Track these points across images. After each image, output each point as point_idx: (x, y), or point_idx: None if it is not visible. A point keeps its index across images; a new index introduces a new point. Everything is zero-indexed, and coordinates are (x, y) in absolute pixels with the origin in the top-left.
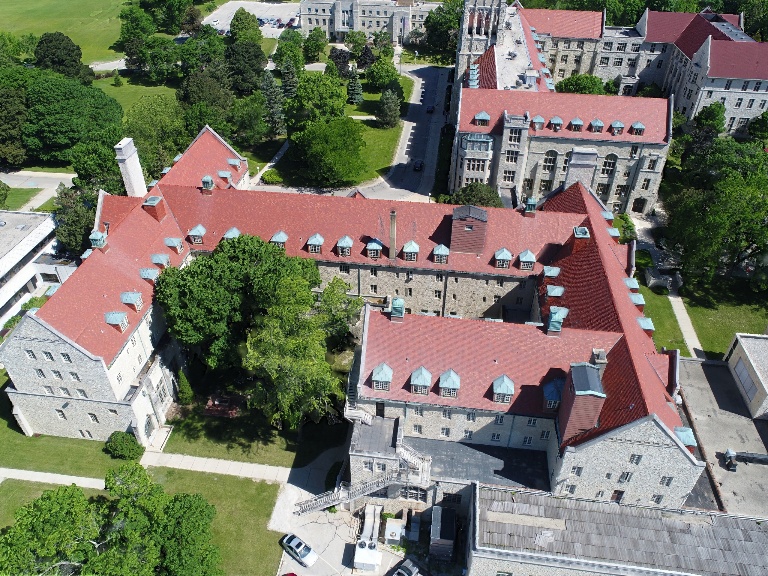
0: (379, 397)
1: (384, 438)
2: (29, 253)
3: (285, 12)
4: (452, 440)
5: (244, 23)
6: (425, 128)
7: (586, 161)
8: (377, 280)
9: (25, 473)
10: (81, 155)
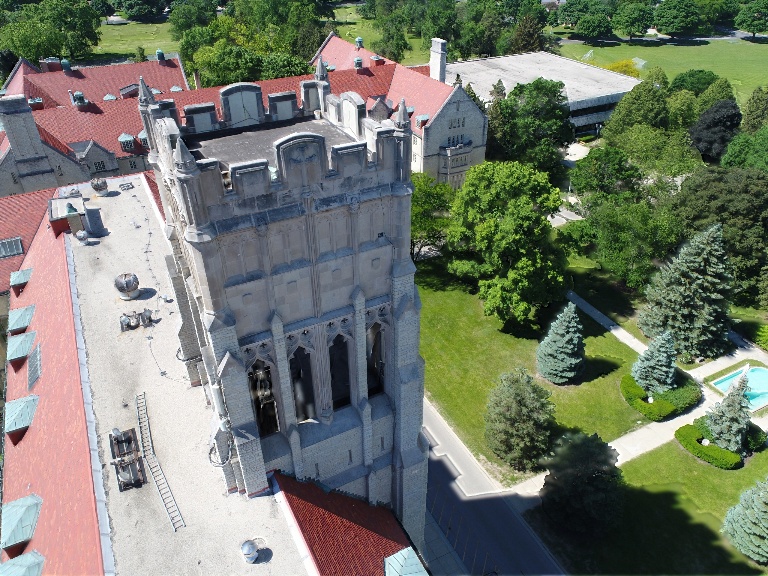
0: None
1: None
2: None
3: None
4: None
5: None
6: None
7: None
8: None
9: None
10: None
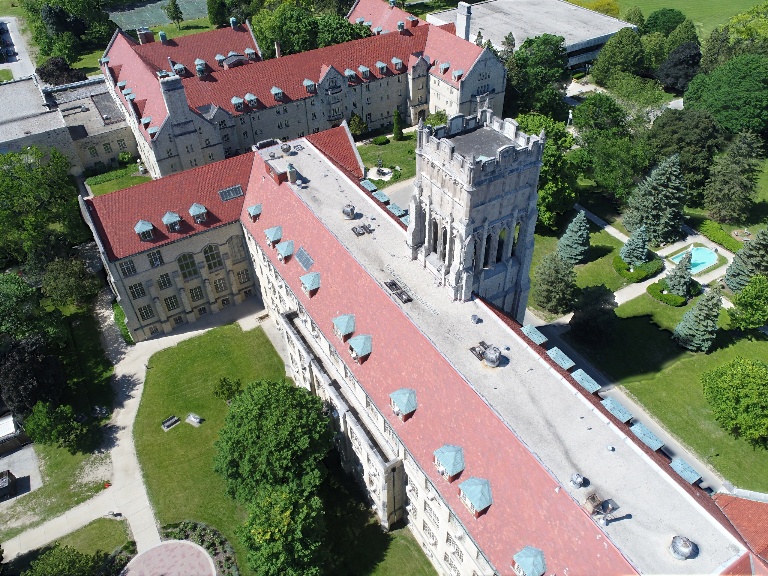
0: None
1: None
2: None
3: None
4: None
5: None
6: None
7: None
8: None
9: None
10: None
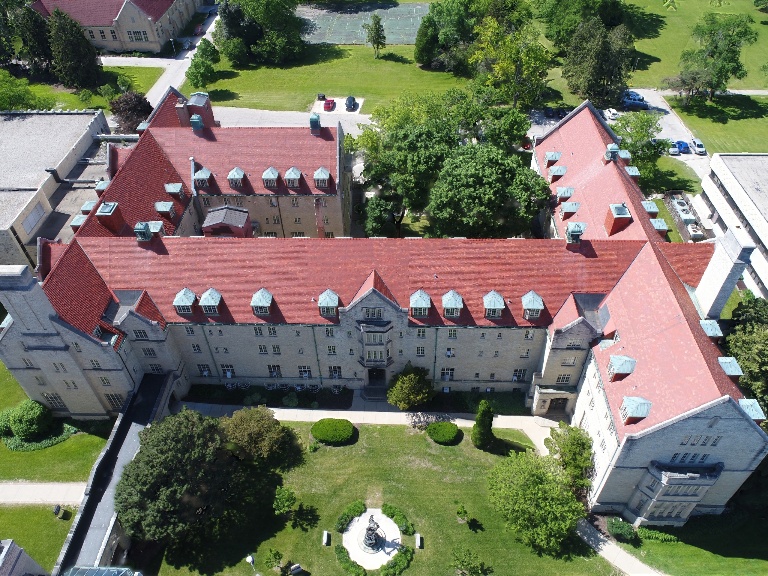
0: None
1: None
2: None
3: None
4: None
5: None
6: None
7: None
8: None
9: None
10: None
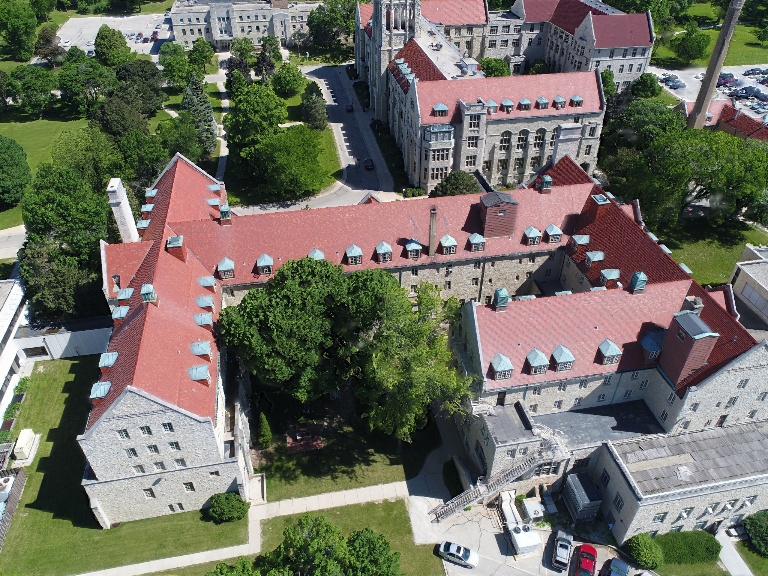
0: (502, 386)
1: (515, 424)
2: (7, 329)
3: (141, 25)
4: (563, 411)
5: (111, 41)
6: (354, 127)
7: (572, 135)
8: (418, 279)
9: (124, 569)
10: (35, 207)
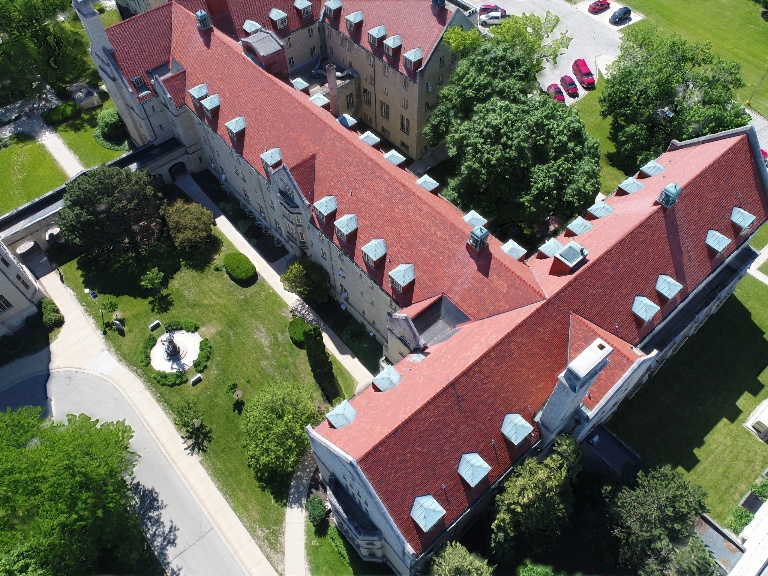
0: None
1: None
2: None
3: None
4: None
5: None
6: None
7: None
8: None
9: None
10: None
